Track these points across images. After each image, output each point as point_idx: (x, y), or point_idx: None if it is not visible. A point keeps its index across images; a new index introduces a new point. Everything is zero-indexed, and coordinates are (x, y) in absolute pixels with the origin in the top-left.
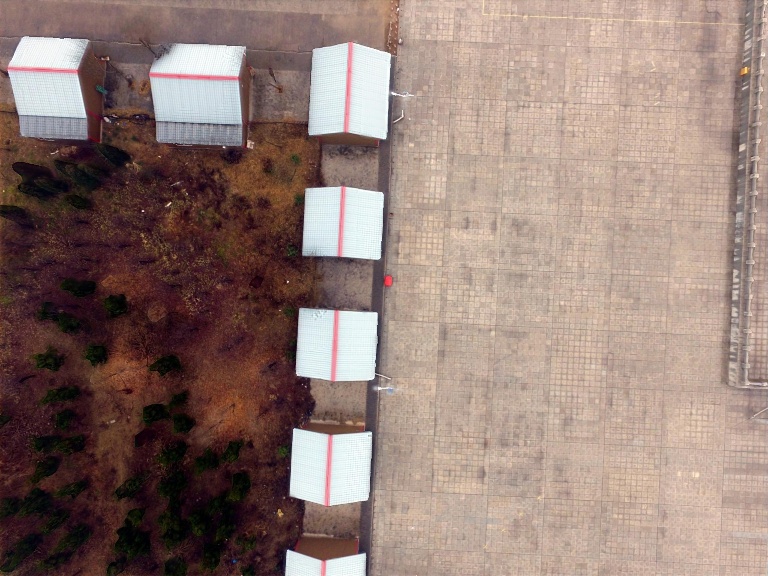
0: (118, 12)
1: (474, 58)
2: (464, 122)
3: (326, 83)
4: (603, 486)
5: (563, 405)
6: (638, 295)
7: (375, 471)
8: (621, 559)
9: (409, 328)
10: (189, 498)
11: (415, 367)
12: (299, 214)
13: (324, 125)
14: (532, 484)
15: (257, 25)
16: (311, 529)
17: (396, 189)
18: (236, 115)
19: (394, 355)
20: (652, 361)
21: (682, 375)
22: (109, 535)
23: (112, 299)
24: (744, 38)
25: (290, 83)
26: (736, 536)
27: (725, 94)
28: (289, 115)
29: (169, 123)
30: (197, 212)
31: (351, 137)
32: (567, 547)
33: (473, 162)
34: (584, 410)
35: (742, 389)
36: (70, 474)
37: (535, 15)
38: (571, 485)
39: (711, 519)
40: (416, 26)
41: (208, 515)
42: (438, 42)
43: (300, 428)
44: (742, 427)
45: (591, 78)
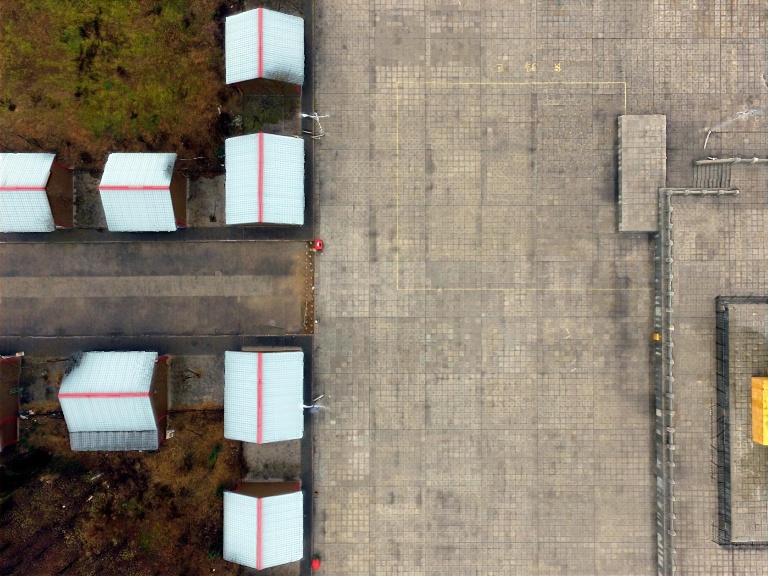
0: (32, 305)
1: (391, 333)
2: (384, 397)
3: (239, 389)
4: None
5: None
6: (565, 562)
7: None
8: None
9: None
10: None
11: None
12: None
13: (239, 431)
14: None
15: (173, 310)
16: None
17: (319, 467)
18: (150, 423)
19: None
20: None
21: None
22: None
23: None
24: (655, 303)
25: (208, 368)
26: None
27: (640, 358)
28: (208, 400)
29: (83, 433)
30: (119, 505)
31: None
32: None
33: (395, 437)
34: None
35: None
36: None
37: (449, 288)
38: None
39: None
40: (332, 304)
41: None
42: (354, 319)
43: None
44: None
45: (507, 347)
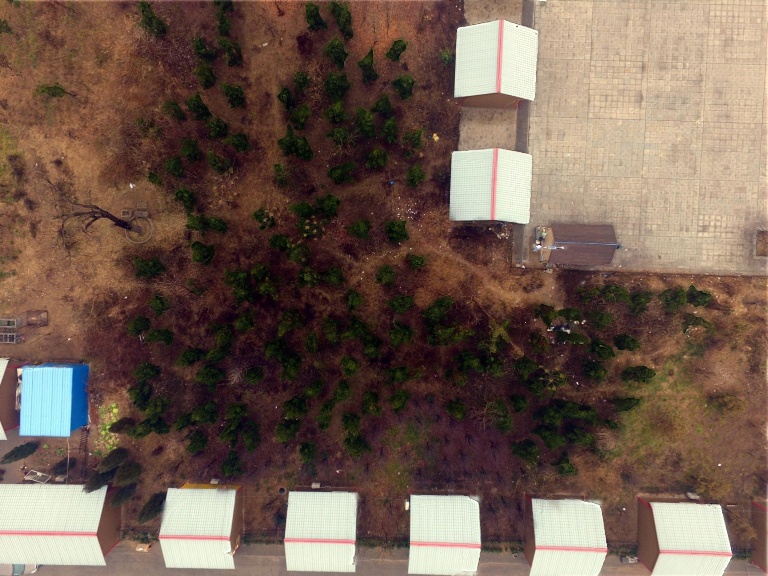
0: None
1: None
2: None
3: None
4: (764, 108)
5: (724, 25)
6: None
7: None
8: None
9: None
10: None
11: None
12: None
13: None
14: (691, 108)
15: None
16: None
17: None
18: None
19: None
20: None
21: None
22: (264, 160)
23: None
24: None
25: None
26: None
27: None
28: None
29: None
30: None
31: None
32: (726, 171)
33: None
34: (745, 30)
35: None
36: (224, 98)
37: None
38: (731, 108)
39: None
40: None
41: None
42: None
43: (465, 26)
44: None
45: None
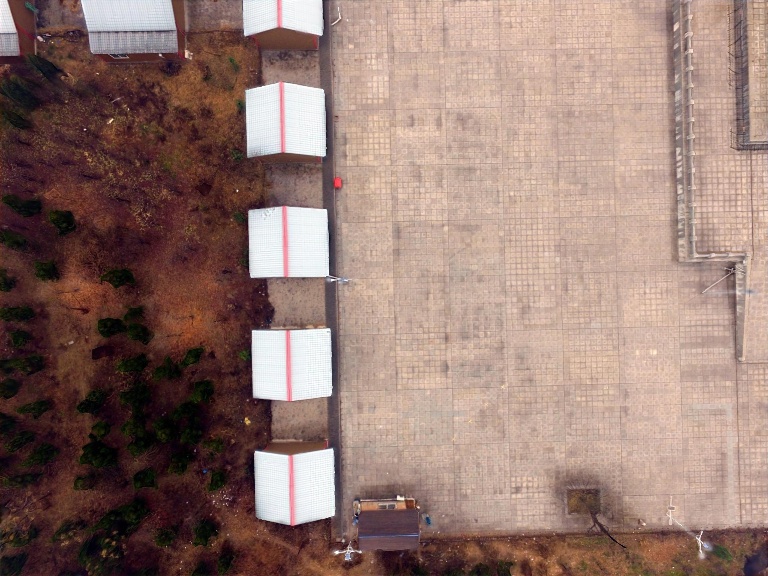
0: None
1: None
2: (402, 20)
3: None
4: (564, 370)
5: (520, 294)
6: (585, 180)
7: (339, 373)
8: (587, 440)
9: (362, 229)
10: (154, 413)
11: (371, 267)
12: (244, 122)
13: (259, 24)
14: (495, 374)
15: None
16: (279, 435)
17: (339, 92)
18: (169, 20)
19: (349, 257)
20: (603, 244)
21: (634, 256)
22: (76, 456)
23: (57, 212)
24: None
25: None
26: (696, 408)
27: None
28: (226, 24)
29: (102, 33)
30: (140, 127)
31: (288, 37)
32: (533, 433)
33: (414, 59)
34: (541, 297)
35: (692, 265)
36: (32, 398)
37: None
38: (533, 372)
39: (671, 394)
40: None
41: (173, 424)
42: None
43: (258, 329)
44: (695, 302)
45: None
